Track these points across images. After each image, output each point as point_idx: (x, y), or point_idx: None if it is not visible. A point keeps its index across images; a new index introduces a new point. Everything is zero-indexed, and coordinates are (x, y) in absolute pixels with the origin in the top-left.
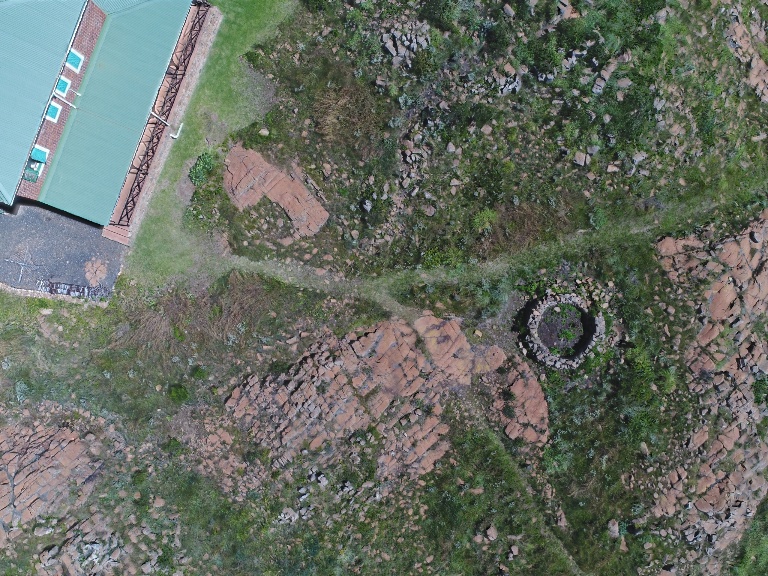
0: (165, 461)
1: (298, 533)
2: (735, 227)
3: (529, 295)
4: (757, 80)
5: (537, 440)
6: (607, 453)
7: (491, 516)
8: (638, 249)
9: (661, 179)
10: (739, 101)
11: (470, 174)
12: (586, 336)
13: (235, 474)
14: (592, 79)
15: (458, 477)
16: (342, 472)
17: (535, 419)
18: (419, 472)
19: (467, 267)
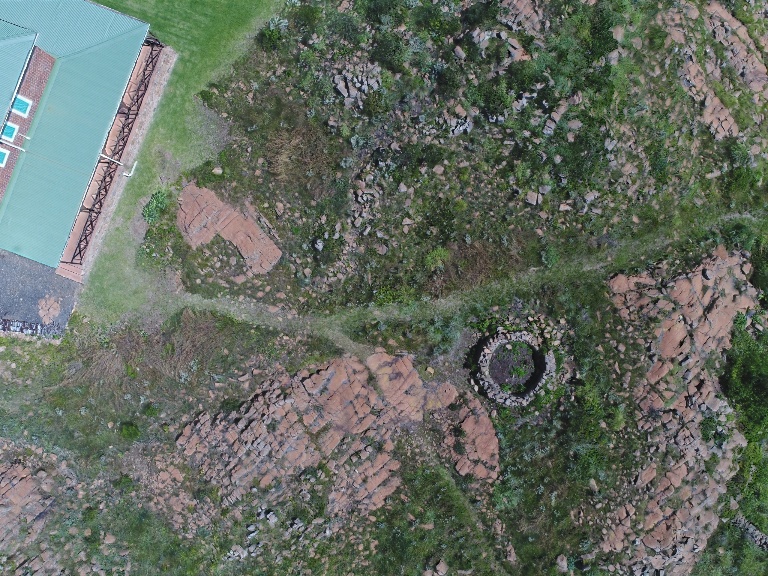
0: (116, 497)
1: (247, 570)
2: (688, 264)
3: (481, 332)
4: (711, 118)
5: (487, 476)
6: (556, 489)
7: (441, 551)
8: (590, 287)
9: (614, 217)
10: (693, 139)
11: (422, 213)
12: (537, 373)
13: (185, 511)
14: (543, 121)
15: (409, 513)
16: (292, 509)
17: (485, 456)
18: (370, 508)
19: (420, 304)
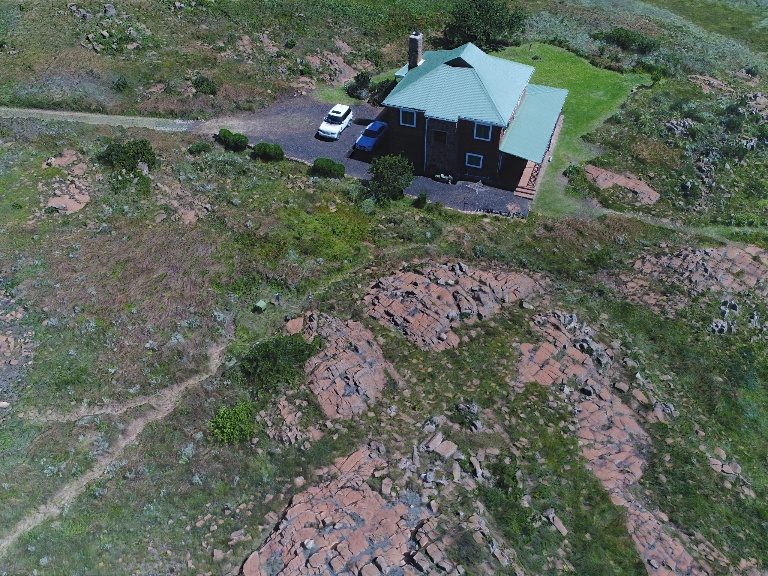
0: (596, 298)
1: (732, 340)
2: None
3: None
4: None
5: None
6: None
7: None
8: None
9: None
10: None
11: (743, 183)
12: None
13: (660, 302)
14: None
15: None
16: None
17: None
18: None
19: (765, 228)
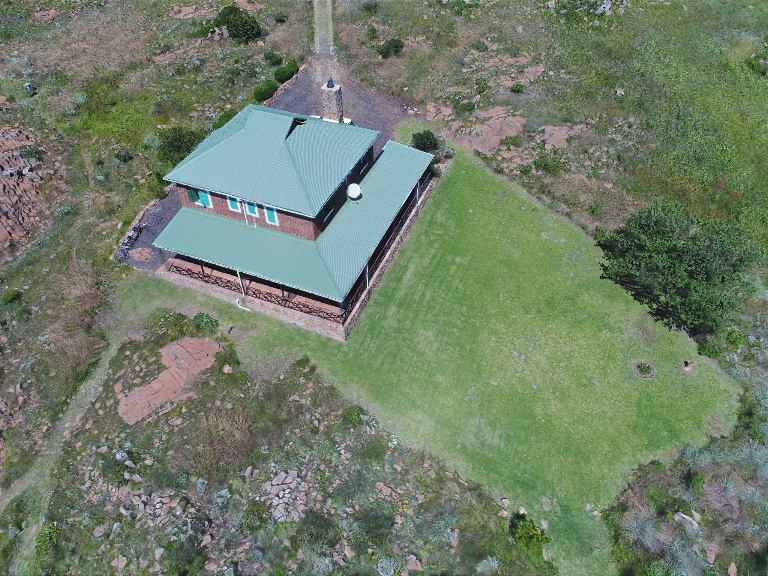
0: None
1: None
2: None
3: None
4: None
5: None
6: None
7: None
8: None
9: None
10: None
11: None
12: None
13: None
14: None
15: None
16: None
17: None
18: None
19: None
